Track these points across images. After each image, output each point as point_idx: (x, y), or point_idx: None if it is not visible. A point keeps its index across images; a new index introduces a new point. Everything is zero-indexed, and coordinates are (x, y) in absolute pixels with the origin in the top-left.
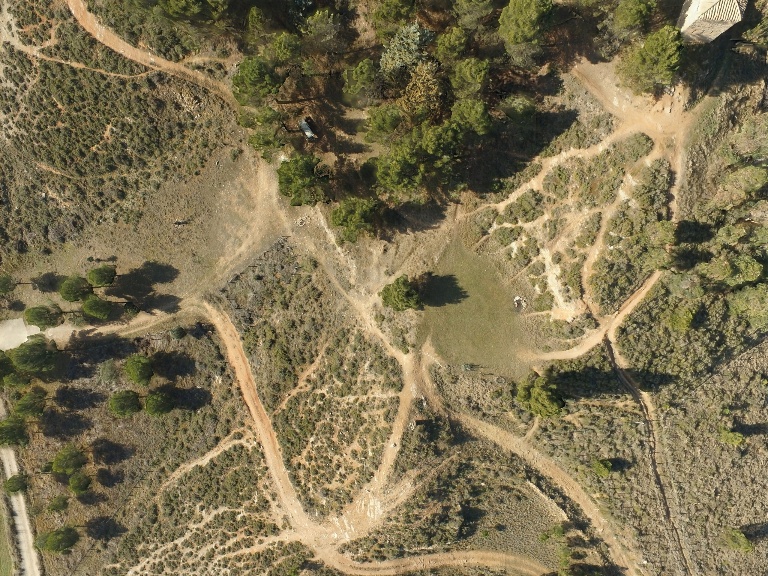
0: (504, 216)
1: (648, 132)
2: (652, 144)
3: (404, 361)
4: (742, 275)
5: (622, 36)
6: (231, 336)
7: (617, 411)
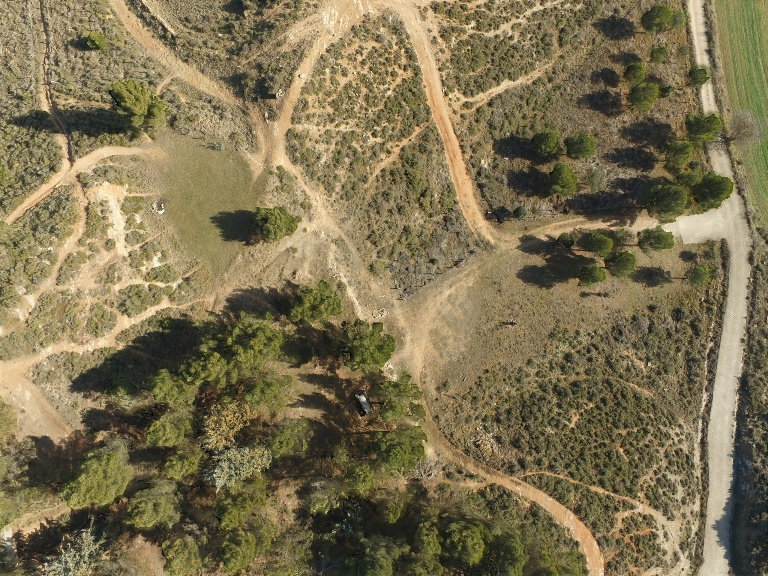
0: (162, 294)
1: None
2: None
3: (283, 159)
4: None
5: (6, 457)
6: (468, 206)
7: (75, 95)
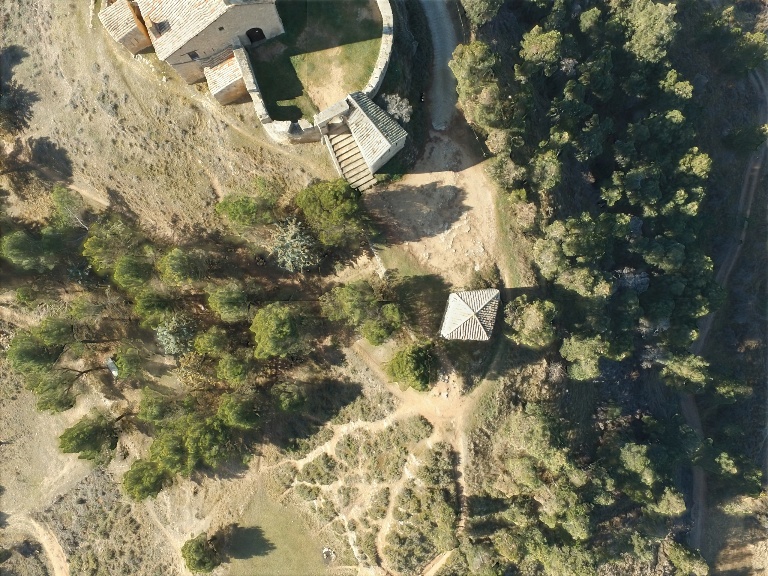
0: (302, 476)
1: (427, 415)
2: (431, 428)
3: None
4: (532, 556)
5: None
6: (58, 557)
7: None
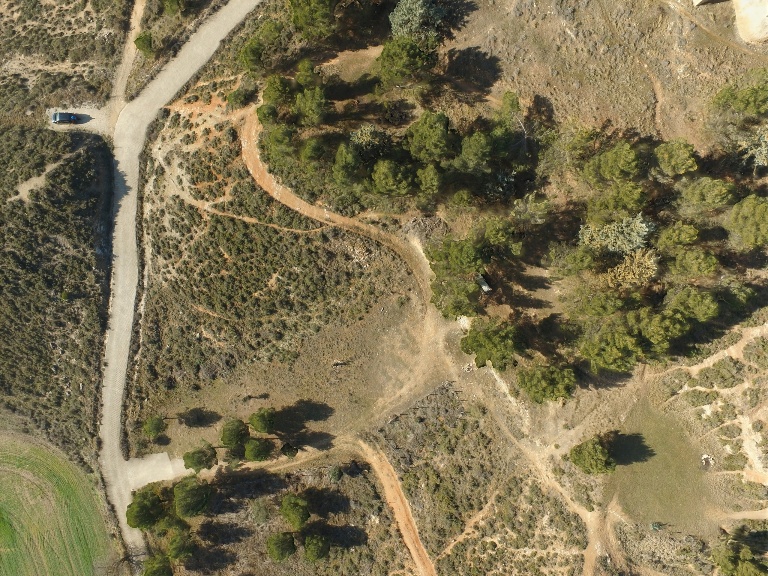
0: (698, 380)
1: None
2: None
3: (588, 518)
4: None
5: None
6: (388, 476)
7: None
